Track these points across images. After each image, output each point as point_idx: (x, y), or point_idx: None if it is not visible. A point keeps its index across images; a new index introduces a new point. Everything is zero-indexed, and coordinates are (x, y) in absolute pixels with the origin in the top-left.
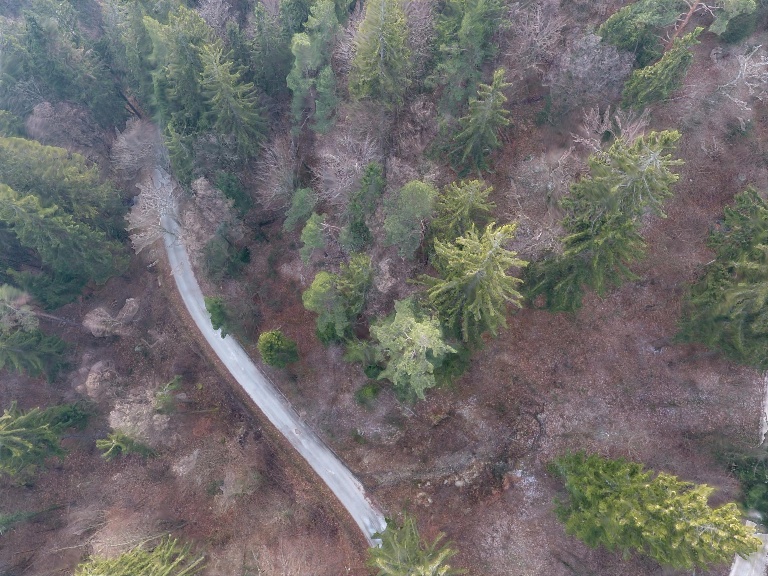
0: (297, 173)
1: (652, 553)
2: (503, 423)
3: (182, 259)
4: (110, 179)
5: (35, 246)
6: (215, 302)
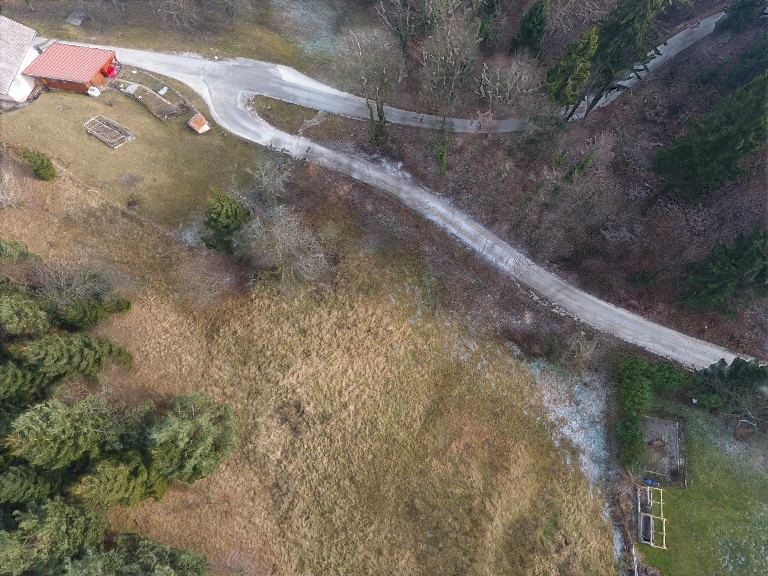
0: None
1: None
2: None
3: None
4: None
5: None
6: None
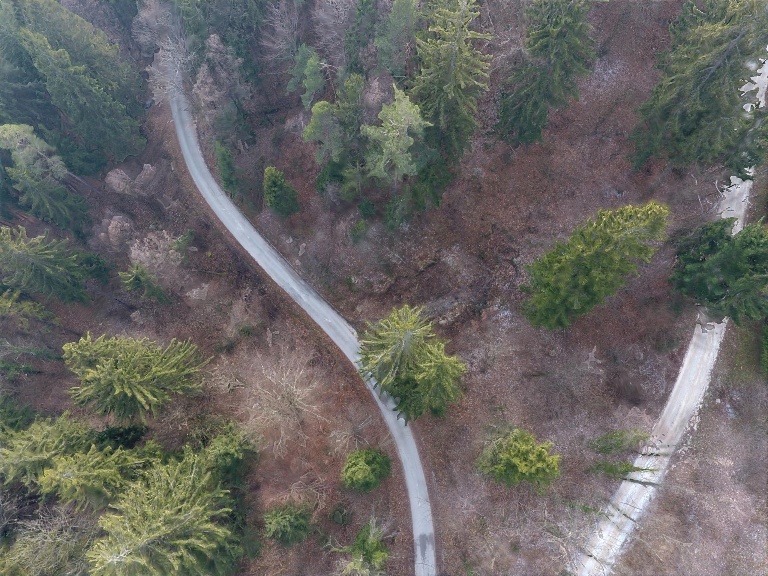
0: (300, 39)
1: (595, 287)
2: (483, 271)
3: (193, 148)
4: (129, 63)
5: (65, 100)
6: (225, 152)
